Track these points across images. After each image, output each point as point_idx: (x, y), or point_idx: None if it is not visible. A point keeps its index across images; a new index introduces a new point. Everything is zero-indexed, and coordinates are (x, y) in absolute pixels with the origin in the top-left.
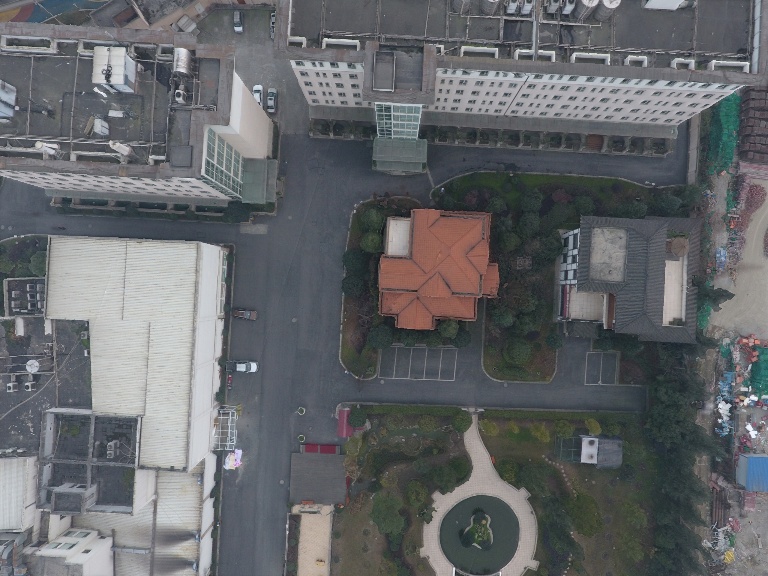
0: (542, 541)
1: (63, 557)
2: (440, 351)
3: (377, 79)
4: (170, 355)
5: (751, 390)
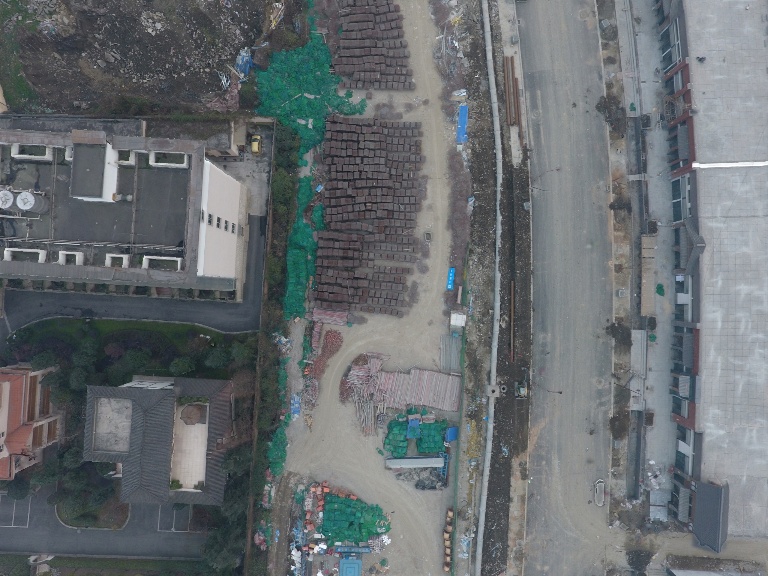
0: None
1: None
2: None
3: None
4: None
5: (325, 537)
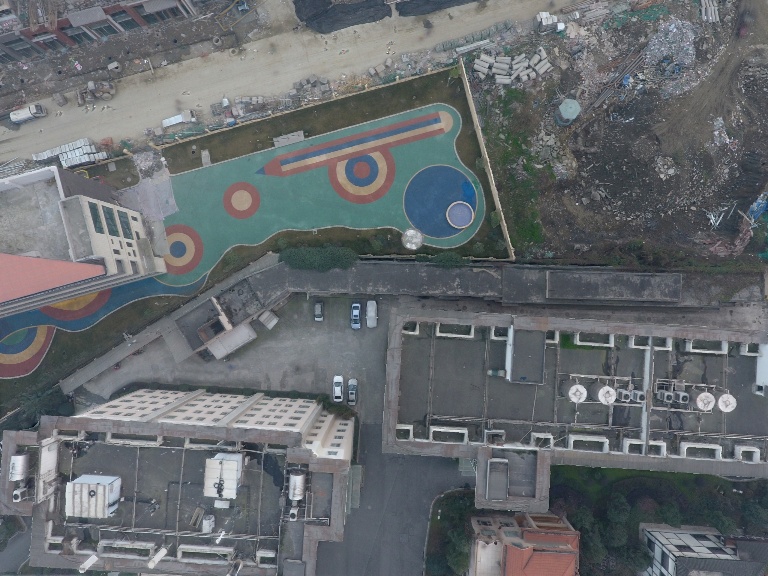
0: None
1: None
2: None
3: (491, 489)
4: None
5: None
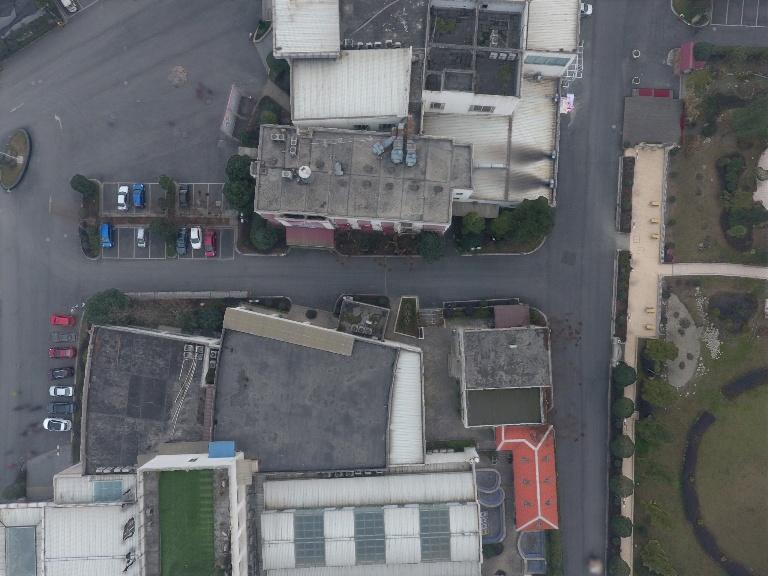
0: None
1: (451, 138)
2: None
3: None
4: None
5: None
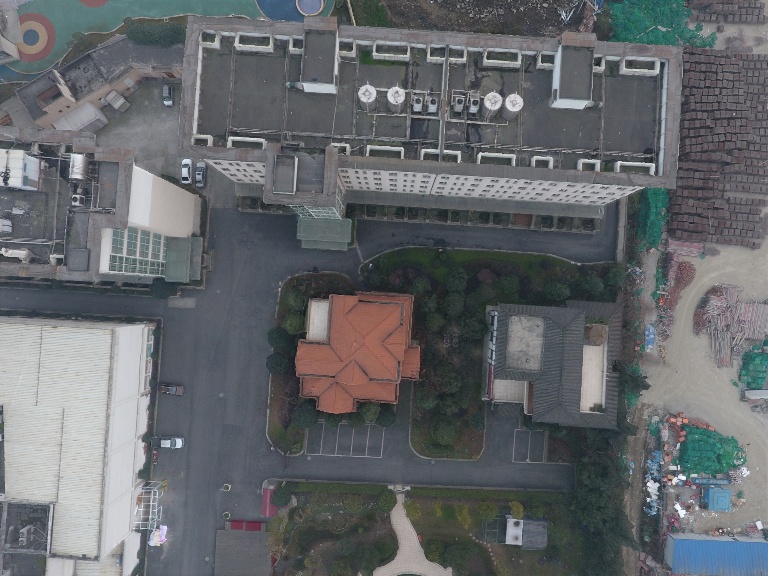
0: None
1: None
2: (367, 427)
3: (277, 182)
4: (83, 442)
5: (680, 469)
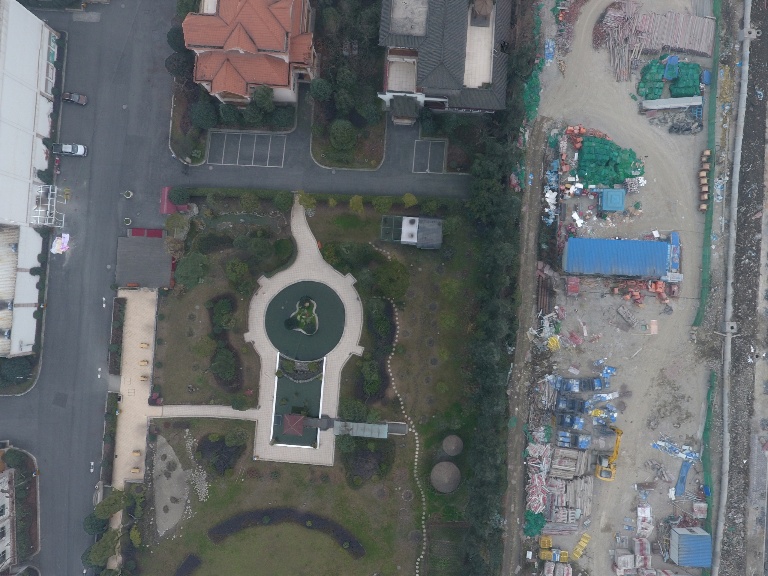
0: (367, 326)
1: None
2: (269, 138)
3: None
4: None
5: (578, 180)
